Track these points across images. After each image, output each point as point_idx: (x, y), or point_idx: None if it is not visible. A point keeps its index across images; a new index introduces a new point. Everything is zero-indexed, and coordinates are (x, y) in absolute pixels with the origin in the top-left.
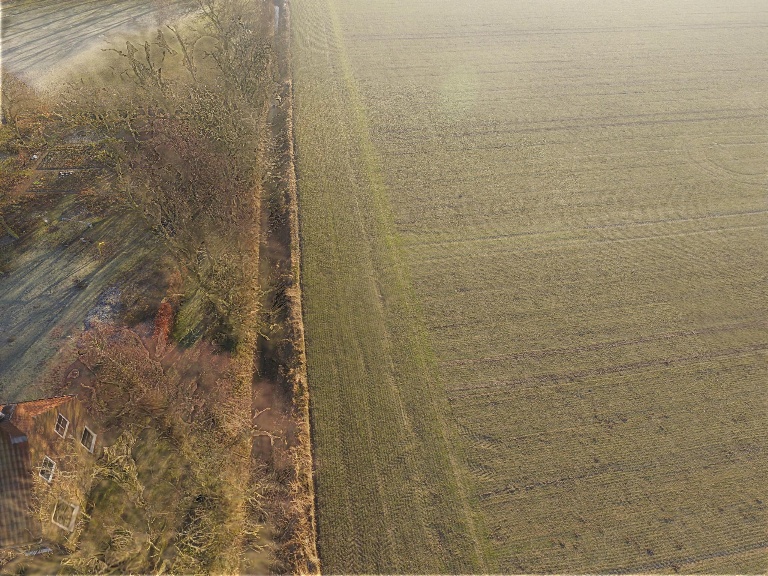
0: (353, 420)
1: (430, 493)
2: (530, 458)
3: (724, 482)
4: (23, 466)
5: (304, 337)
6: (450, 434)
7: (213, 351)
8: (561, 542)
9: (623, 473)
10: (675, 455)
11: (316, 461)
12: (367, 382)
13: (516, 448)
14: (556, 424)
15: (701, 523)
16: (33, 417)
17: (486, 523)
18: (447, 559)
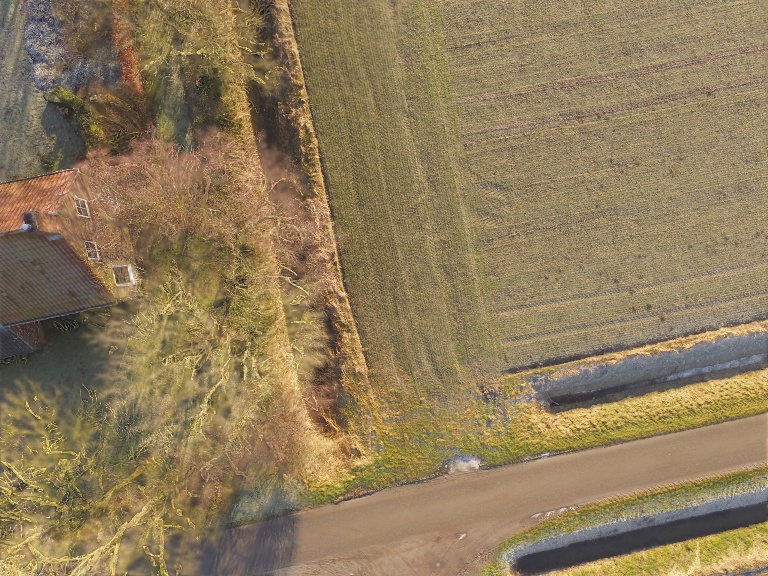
0: (366, 170)
1: (440, 240)
2: (536, 205)
3: (705, 222)
4: (71, 256)
5: (301, 64)
6: (463, 183)
7: (199, 89)
8: (546, 276)
9: (618, 217)
10: (672, 198)
11: (334, 213)
12: (379, 126)
13: (525, 196)
14: (569, 170)
15: (668, 258)
16: (55, 214)
17: (486, 263)
18: (451, 291)
